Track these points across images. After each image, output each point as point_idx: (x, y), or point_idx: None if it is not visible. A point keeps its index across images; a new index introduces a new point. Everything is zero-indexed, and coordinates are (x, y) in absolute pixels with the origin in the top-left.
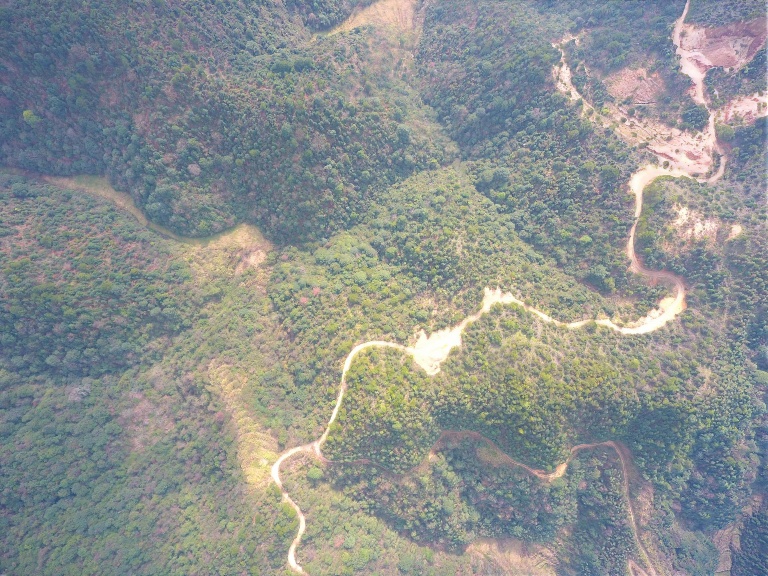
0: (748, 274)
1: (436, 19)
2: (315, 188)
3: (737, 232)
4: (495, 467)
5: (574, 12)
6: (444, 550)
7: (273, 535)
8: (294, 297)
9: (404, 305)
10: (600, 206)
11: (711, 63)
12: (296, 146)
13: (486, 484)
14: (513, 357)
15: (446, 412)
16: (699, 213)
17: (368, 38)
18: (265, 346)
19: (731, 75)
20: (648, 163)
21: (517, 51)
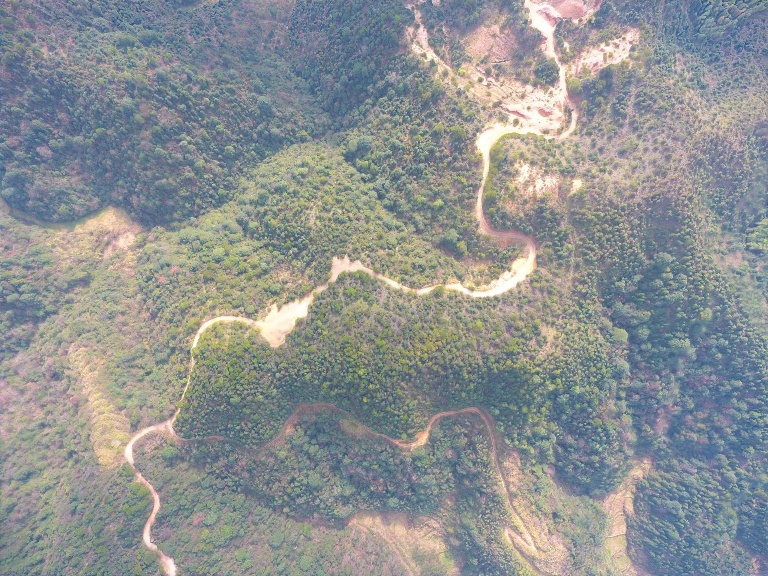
0: (590, 229)
1: None
2: (172, 166)
3: (578, 187)
4: (359, 439)
5: None
6: (325, 525)
7: (122, 515)
8: (155, 277)
9: (261, 279)
10: (452, 169)
11: (560, 15)
12: (141, 122)
13: (351, 456)
14: (349, 324)
15: (290, 384)
16: (540, 169)
17: (232, 11)
18: (128, 328)
19: (579, 26)
20: (496, 122)
21: (371, 14)
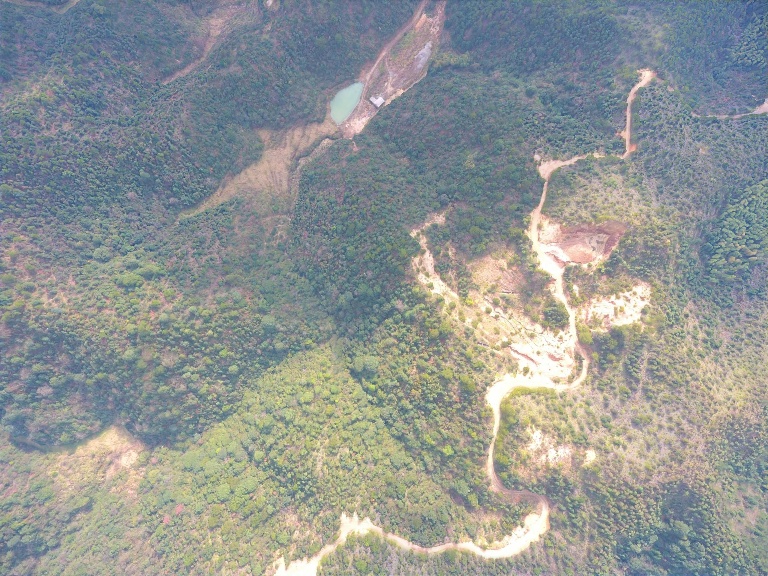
0: (605, 503)
1: (309, 184)
2: (175, 396)
3: (591, 459)
4: None
5: (442, 183)
6: None
7: None
8: (159, 513)
9: (267, 524)
10: (462, 414)
11: (569, 258)
12: (144, 367)
13: None
14: None
15: None
16: (552, 438)
17: (234, 216)
18: (132, 566)
19: (589, 273)
20: (506, 372)
21: (376, 241)
